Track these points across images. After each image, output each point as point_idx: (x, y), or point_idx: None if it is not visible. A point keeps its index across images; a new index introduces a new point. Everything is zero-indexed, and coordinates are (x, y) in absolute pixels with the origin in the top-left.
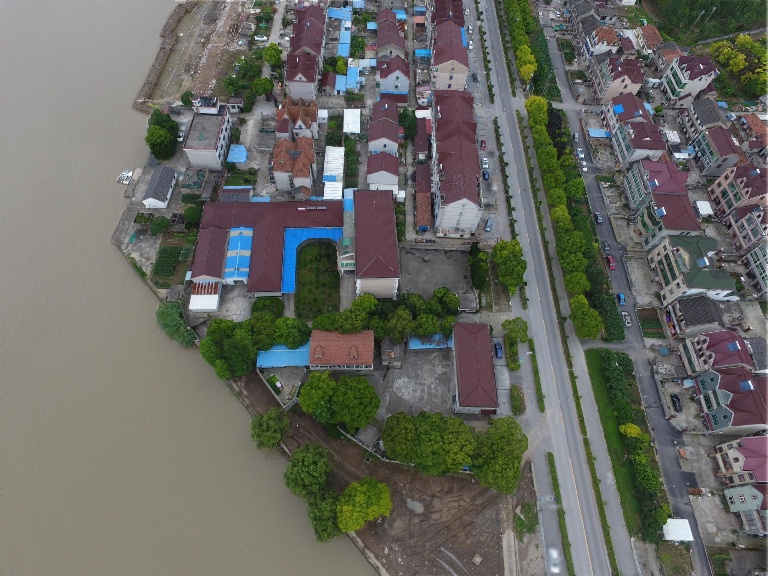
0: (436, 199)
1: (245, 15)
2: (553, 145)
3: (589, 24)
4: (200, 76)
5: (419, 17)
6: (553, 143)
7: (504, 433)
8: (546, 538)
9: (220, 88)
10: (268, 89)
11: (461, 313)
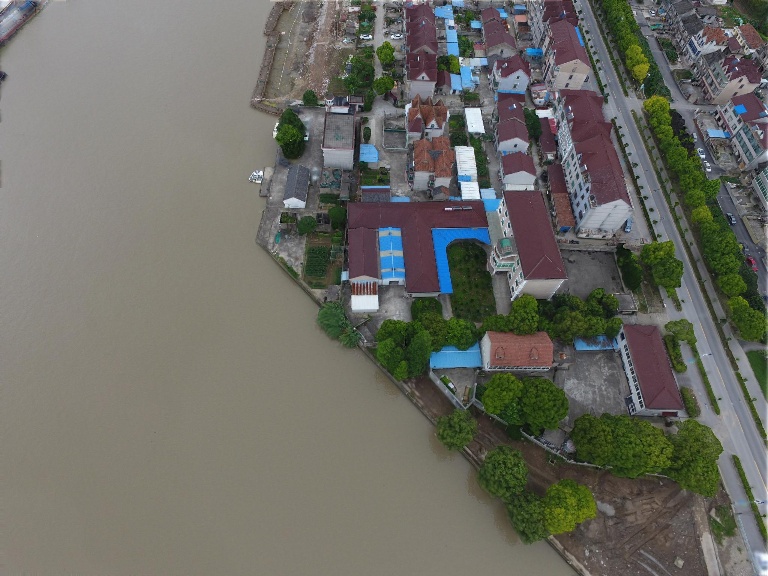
0: (579, 200)
1: (345, 13)
2: (681, 145)
3: (692, 23)
4: (312, 75)
5: (520, 16)
6: (681, 143)
7: (698, 436)
8: (748, 541)
9: (334, 87)
10: (390, 88)
11: (617, 314)
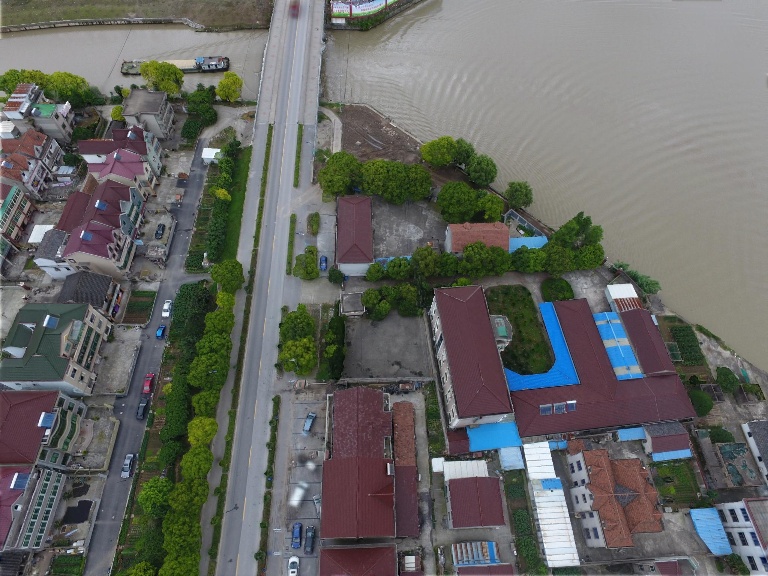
0: None
1: None
2: None
3: None
4: None
5: None
6: None
7: None
8: (312, 144)
9: None
10: None
11: None
